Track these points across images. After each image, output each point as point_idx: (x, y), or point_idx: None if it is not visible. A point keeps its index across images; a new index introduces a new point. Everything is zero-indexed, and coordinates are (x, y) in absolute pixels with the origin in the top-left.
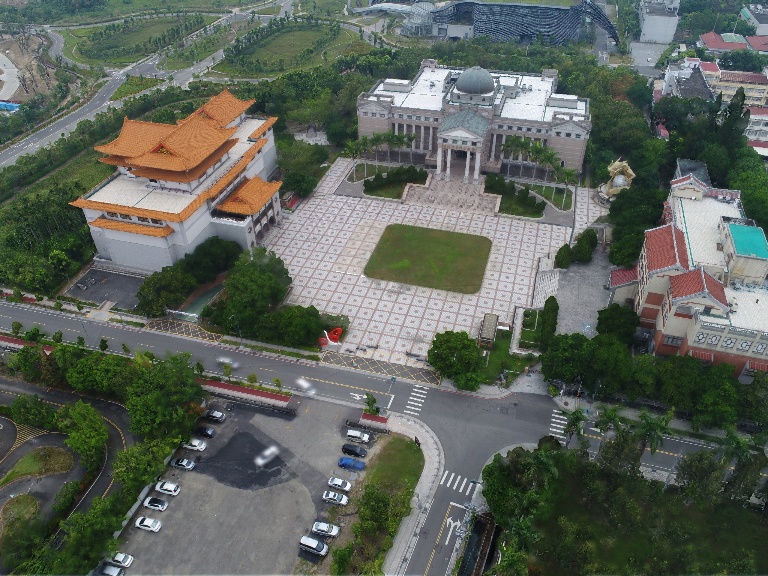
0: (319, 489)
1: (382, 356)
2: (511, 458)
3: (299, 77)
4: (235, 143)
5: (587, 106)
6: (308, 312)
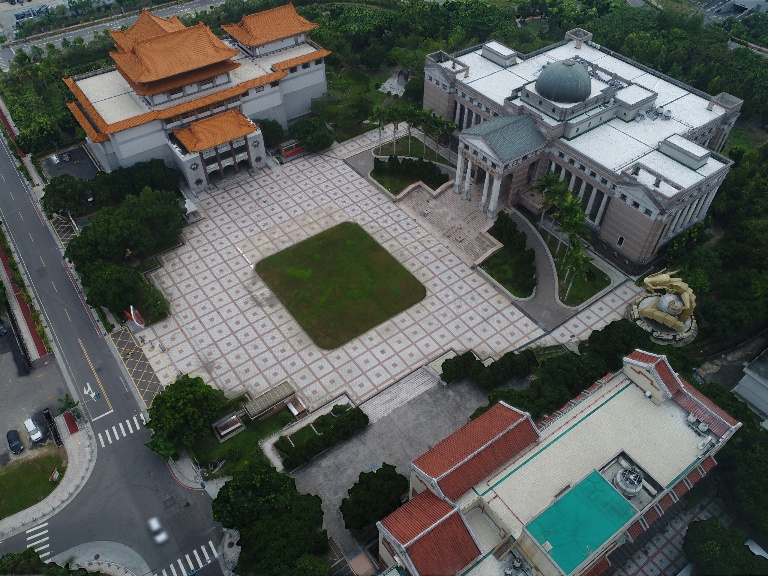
0: None
1: (158, 363)
2: (5, 566)
3: (467, 9)
4: (234, 68)
5: None
6: (120, 279)
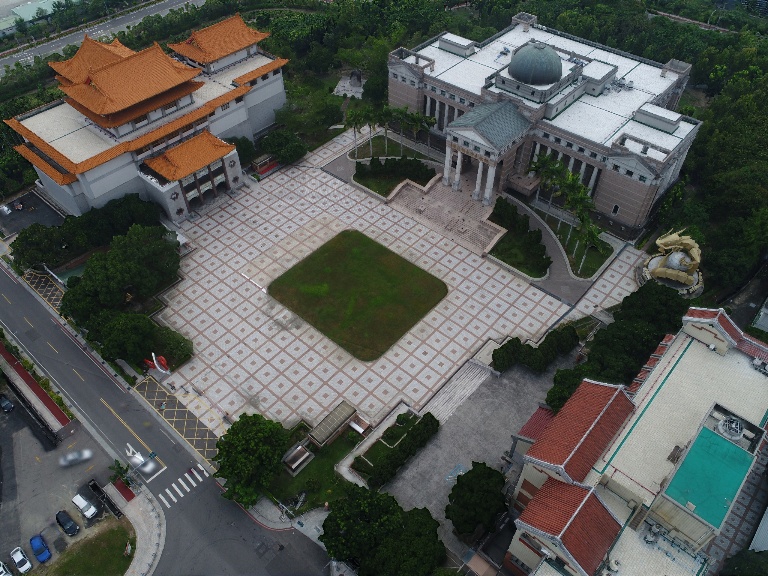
0: (2, 554)
1: (198, 408)
2: None
3: (396, 3)
4: (198, 87)
5: (688, 134)
6: (136, 327)
